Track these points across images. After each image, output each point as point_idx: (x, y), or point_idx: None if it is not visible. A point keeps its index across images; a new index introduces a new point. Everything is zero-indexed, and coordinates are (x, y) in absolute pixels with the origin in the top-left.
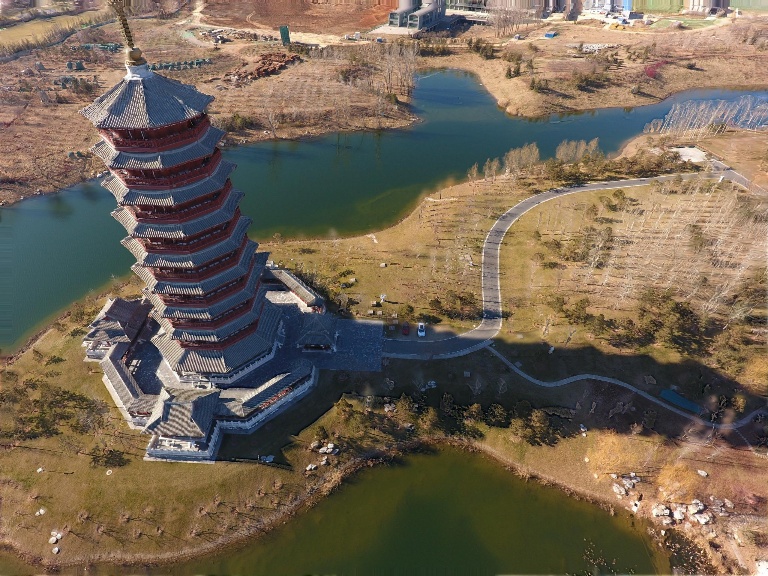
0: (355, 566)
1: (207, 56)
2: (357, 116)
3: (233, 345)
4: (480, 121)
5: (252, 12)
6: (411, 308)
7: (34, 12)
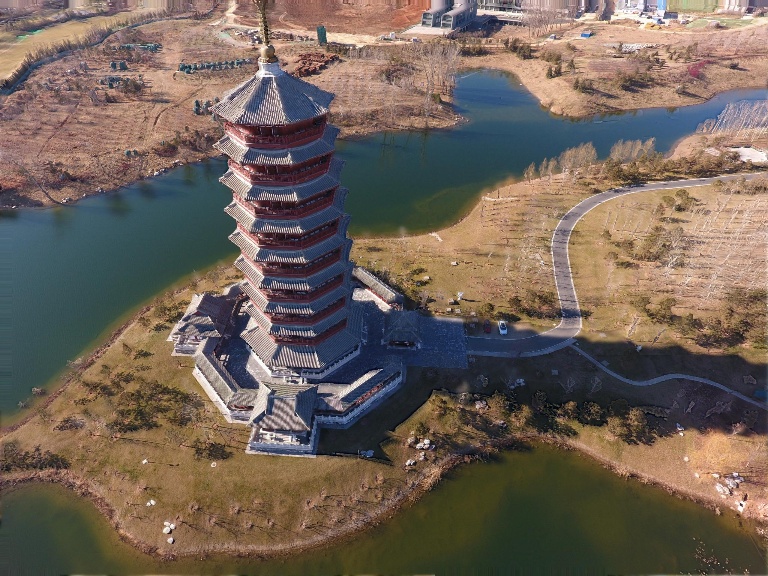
0: (466, 561)
1: (246, 56)
2: (403, 116)
3: (324, 341)
4: (525, 121)
5: (284, 13)
6: (491, 306)
7: (70, 13)
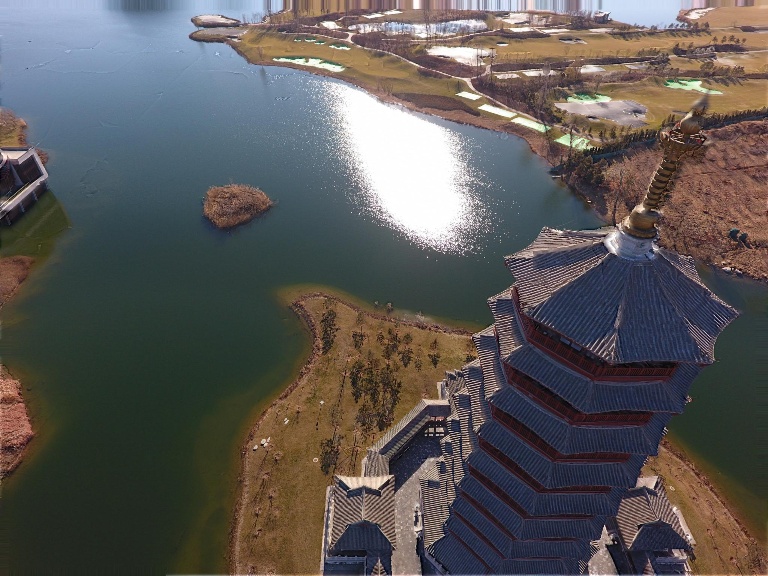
0: None
1: None
2: None
3: None
4: None
5: None
6: None
7: None
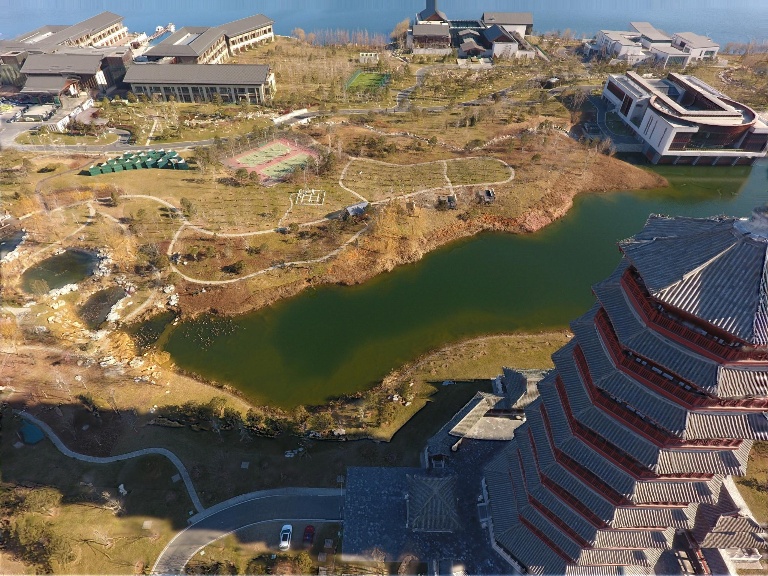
0: None
1: None
2: None
3: None
4: None
5: None
6: None
7: None
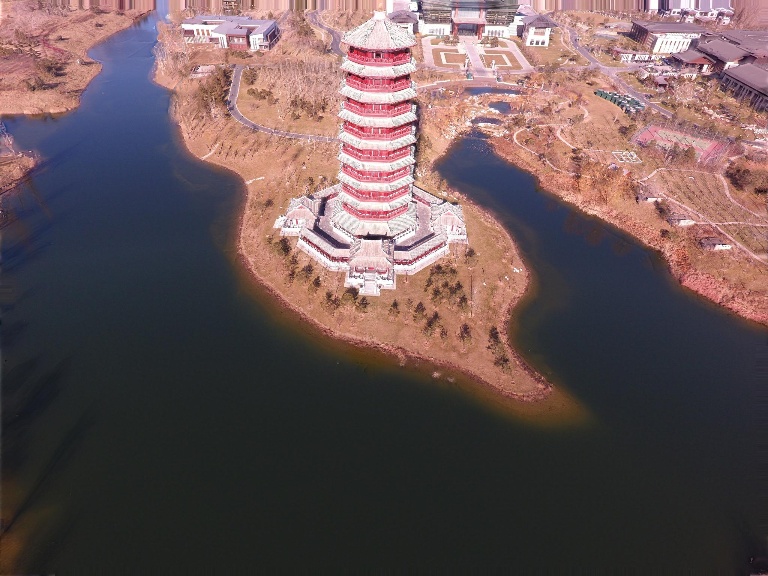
0: None
1: None
2: None
3: None
4: (59, 127)
5: None
6: None
7: None
